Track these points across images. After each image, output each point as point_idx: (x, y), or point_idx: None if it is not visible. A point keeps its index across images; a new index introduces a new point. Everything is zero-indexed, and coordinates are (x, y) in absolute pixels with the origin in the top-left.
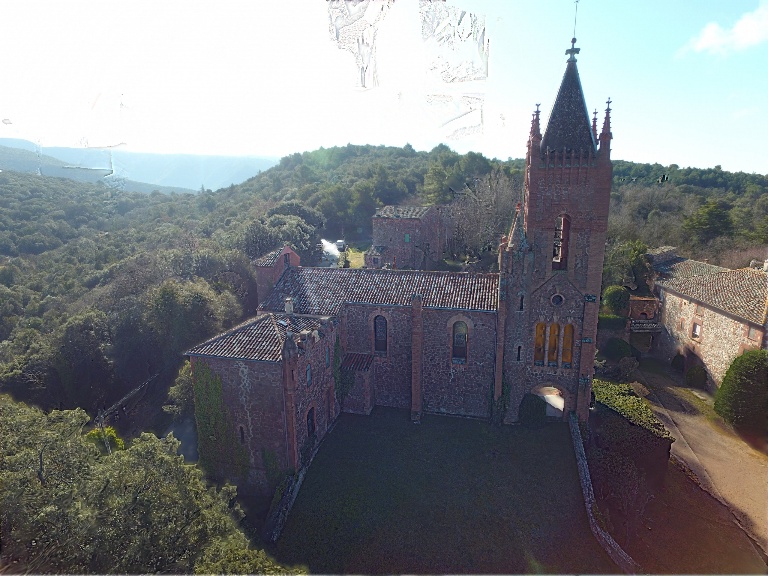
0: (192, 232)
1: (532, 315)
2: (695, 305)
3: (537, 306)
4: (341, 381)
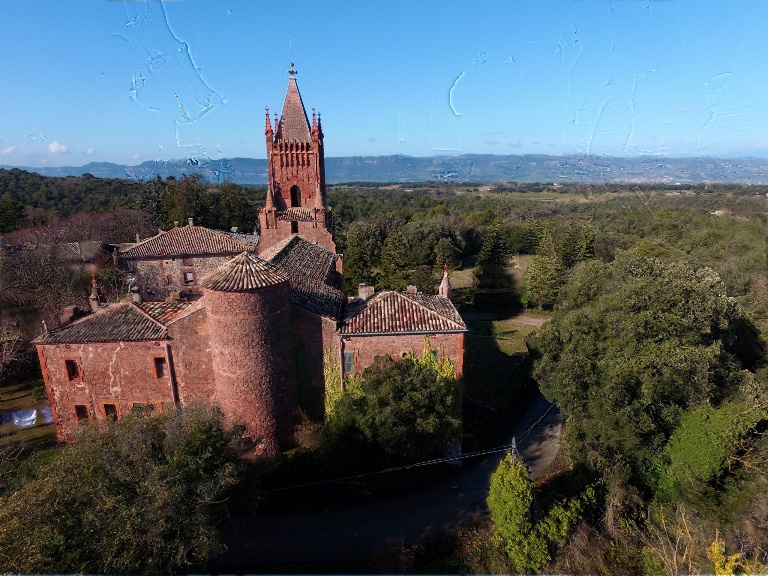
0: None
1: None
2: (181, 260)
3: None
4: None
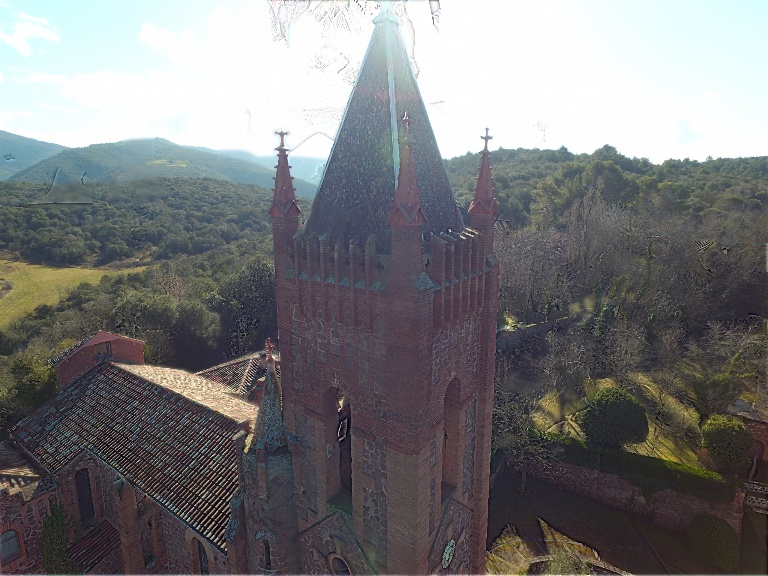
0: (169, 271)
1: (305, 575)
2: None
3: (310, 562)
4: (72, 569)
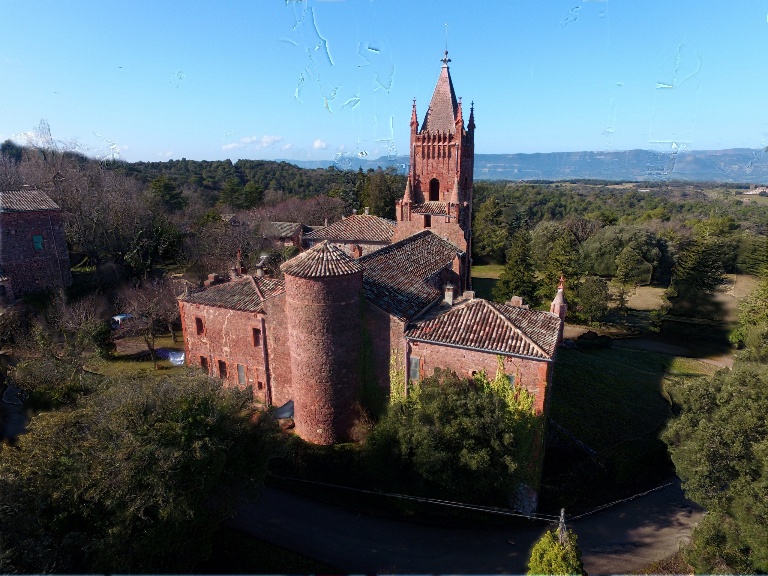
0: None
1: None
2: (351, 245)
3: None
4: None
